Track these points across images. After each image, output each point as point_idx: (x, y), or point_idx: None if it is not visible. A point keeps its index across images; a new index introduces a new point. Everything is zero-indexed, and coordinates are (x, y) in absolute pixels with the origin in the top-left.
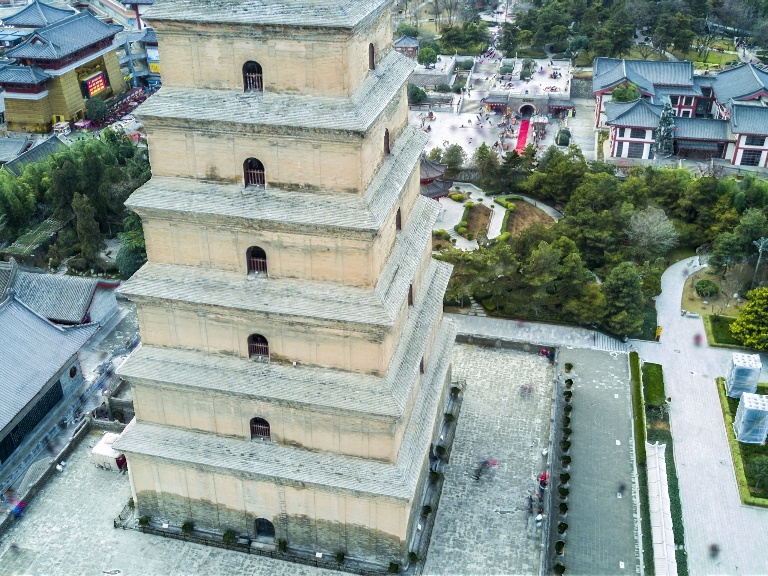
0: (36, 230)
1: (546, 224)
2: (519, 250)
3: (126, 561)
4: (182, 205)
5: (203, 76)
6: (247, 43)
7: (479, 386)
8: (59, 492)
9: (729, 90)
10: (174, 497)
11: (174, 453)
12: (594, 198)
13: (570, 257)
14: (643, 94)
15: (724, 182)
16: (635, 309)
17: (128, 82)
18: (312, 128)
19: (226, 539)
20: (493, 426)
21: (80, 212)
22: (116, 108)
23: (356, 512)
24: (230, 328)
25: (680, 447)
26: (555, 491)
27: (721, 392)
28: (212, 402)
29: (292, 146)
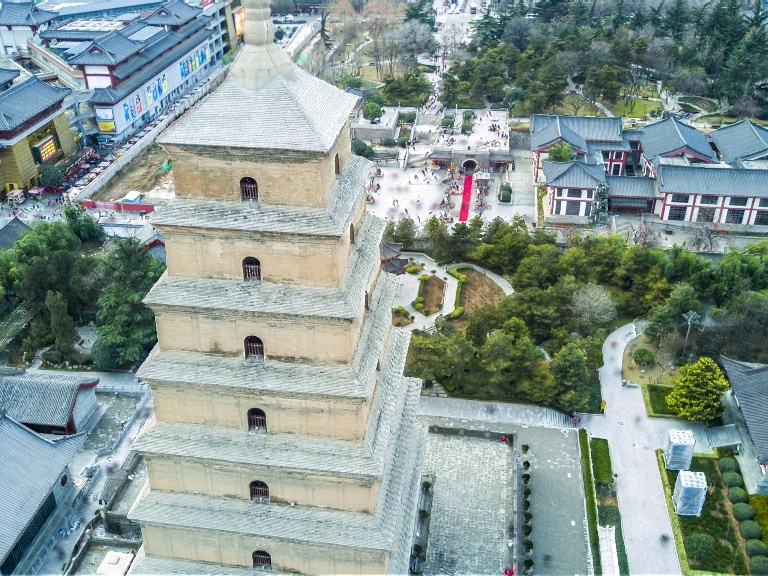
0: (7, 322)
1: (496, 295)
2: (474, 332)
3: None
4: (189, 377)
5: (206, 268)
6: (247, 243)
7: (447, 478)
8: None
9: (655, 145)
10: None
11: None
12: (539, 272)
13: (521, 341)
14: (577, 156)
15: (655, 253)
16: (581, 385)
17: (78, 142)
18: (307, 315)
19: None
20: (463, 519)
21: (54, 309)
22: (68, 171)
23: None
24: (233, 476)
25: (627, 522)
26: None
27: (661, 464)
28: (217, 538)
29: (288, 327)
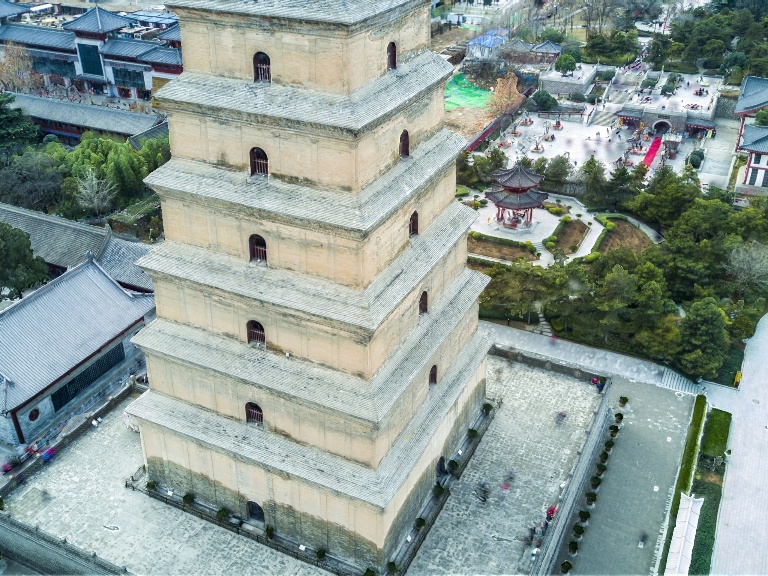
0: (145, 201)
1: (644, 248)
2: (598, 271)
3: (126, 520)
4: (192, 187)
5: (219, 64)
6: (257, 34)
7: (515, 406)
8: (89, 445)
9: None
10: (178, 467)
11: (176, 425)
12: (697, 226)
13: (648, 285)
14: None
15: None
16: (715, 349)
17: None
18: (309, 122)
19: (219, 516)
20: (517, 449)
21: None
22: None
23: (337, 511)
24: (231, 312)
25: (728, 505)
26: (571, 528)
27: None
28: (213, 381)
29: (293, 139)
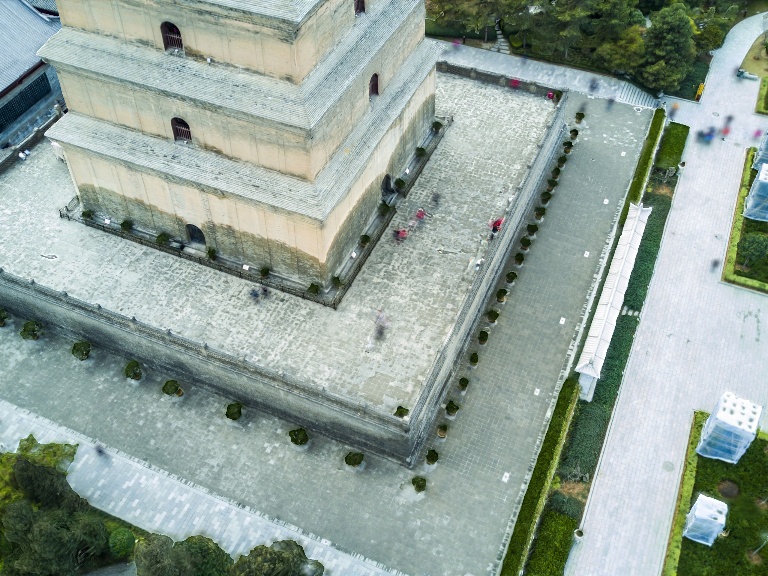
0: None
1: None
2: None
3: (64, 248)
4: None
5: None
6: None
7: (466, 124)
8: (18, 178)
9: None
10: (111, 194)
11: (101, 147)
12: None
13: None
14: None
15: None
16: (679, 61)
17: None
18: None
19: (159, 240)
20: (466, 166)
21: None
22: None
23: (276, 228)
24: (141, 13)
25: (676, 215)
26: (518, 241)
27: (747, 163)
28: (133, 96)
29: None
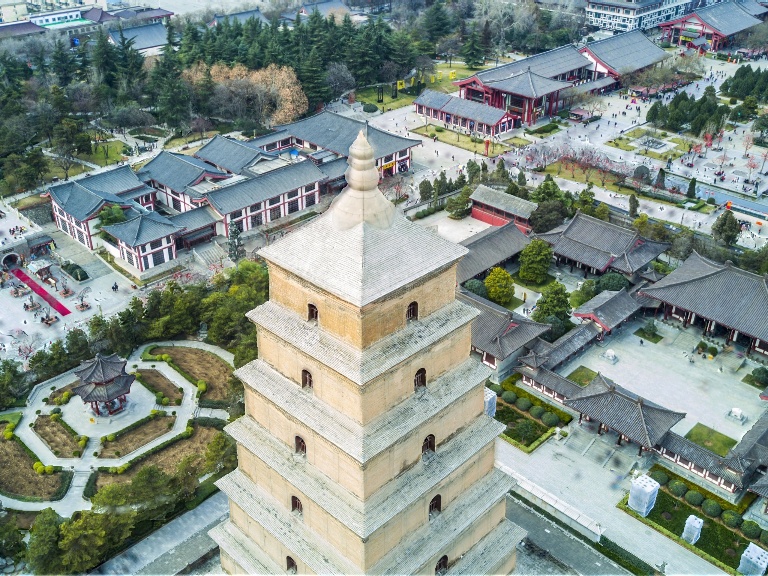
0: None
1: (204, 356)
2: None
3: None
4: (401, 505)
5: (391, 400)
6: (419, 359)
7: None
8: None
9: (173, 179)
10: None
11: None
12: (240, 318)
13: None
14: None
15: None
16: None
17: None
18: None
19: None
20: None
21: None
22: None
23: None
24: (427, 569)
25: None
26: None
27: None
28: None
29: (451, 410)
